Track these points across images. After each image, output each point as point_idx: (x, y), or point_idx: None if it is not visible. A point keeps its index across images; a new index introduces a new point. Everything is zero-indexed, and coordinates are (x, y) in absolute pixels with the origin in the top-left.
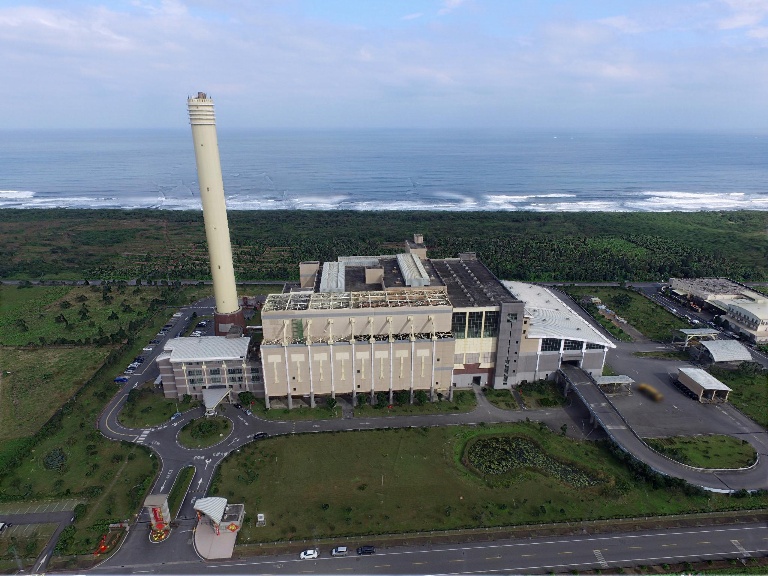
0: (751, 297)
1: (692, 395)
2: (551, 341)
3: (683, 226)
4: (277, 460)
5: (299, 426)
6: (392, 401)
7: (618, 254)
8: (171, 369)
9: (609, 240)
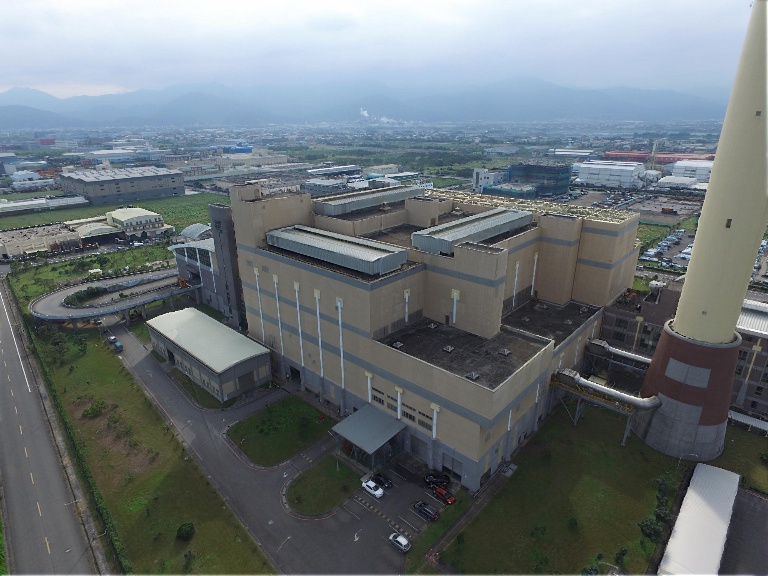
0: (85, 221)
1: None
2: None
3: None
4: None
5: None
6: None
7: None
8: None
9: None
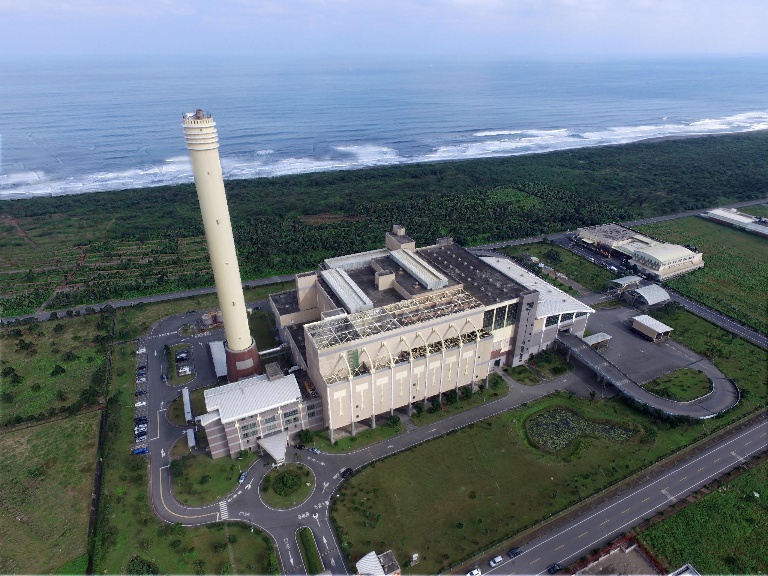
0: (642, 240)
1: (648, 338)
2: (552, 317)
3: (551, 169)
4: (381, 493)
5: (375, 451)
6: (441, 402)
7: (520, 206)
8: (219, 429)
9: (504, 191)
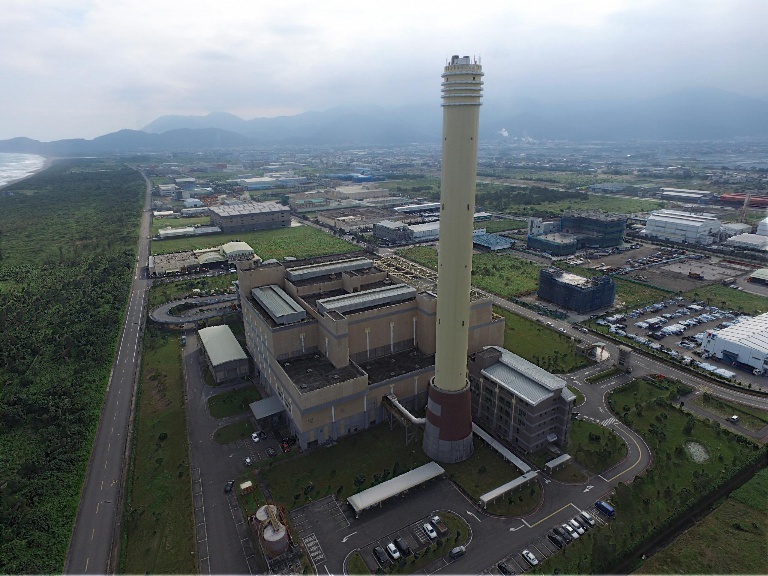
0: (206, 251)
1: None
2: None
3: None
4: None
5: None
6: None
7: None
8: None
9: None
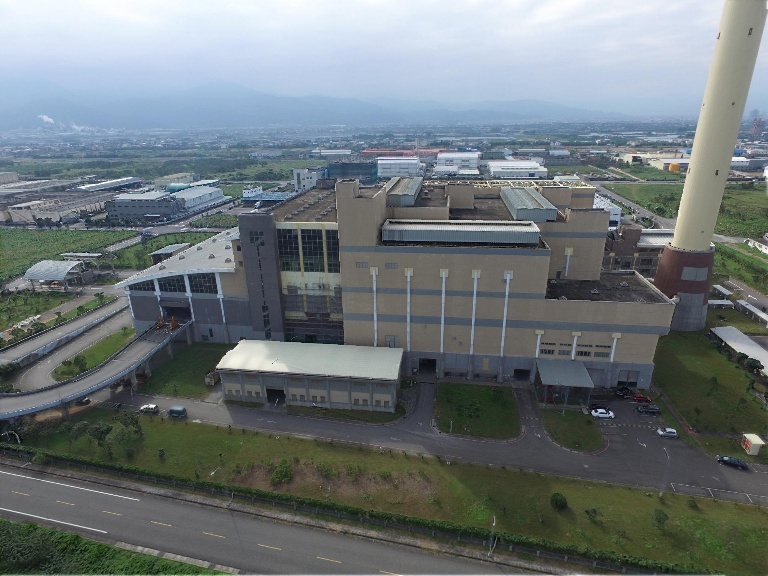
0: None
1: None
2: None
3: None
4: None
5: None
6: None
7: None
8: None
9: None
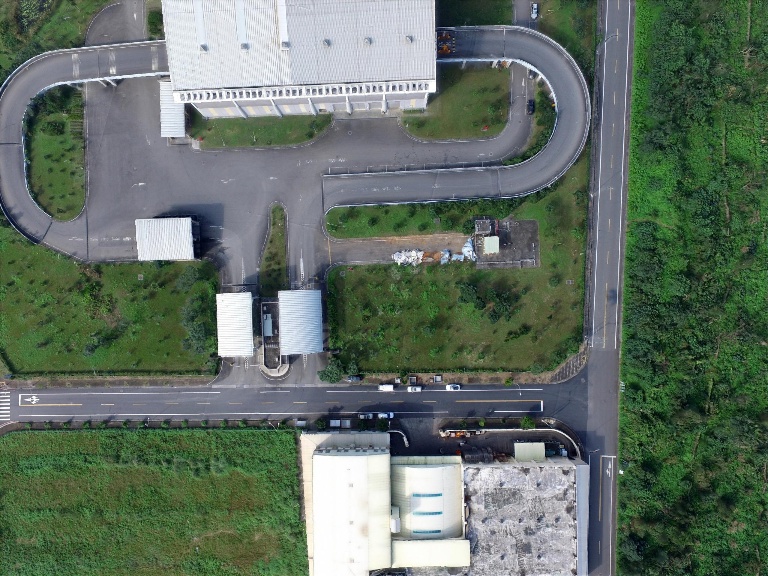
0: (437, 540)
1: (155, 216)
2: None
3: None
4: None
5: None
6: None
7: None
8: None
9: None
